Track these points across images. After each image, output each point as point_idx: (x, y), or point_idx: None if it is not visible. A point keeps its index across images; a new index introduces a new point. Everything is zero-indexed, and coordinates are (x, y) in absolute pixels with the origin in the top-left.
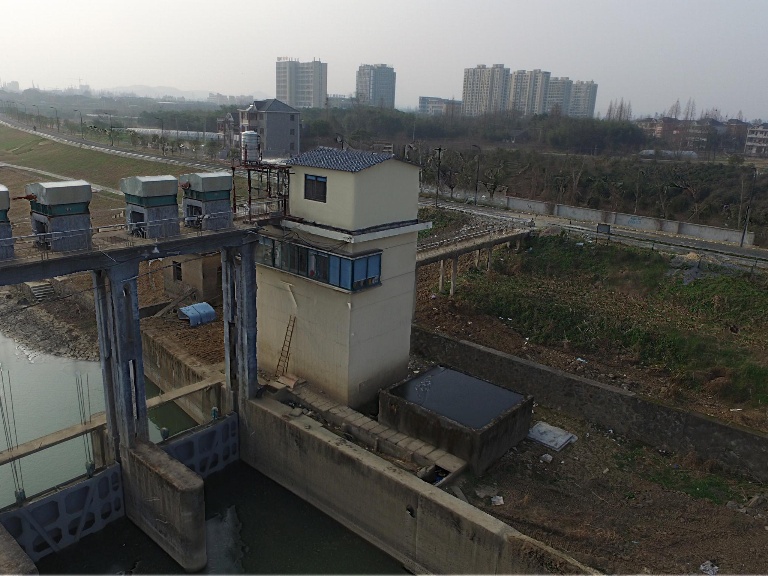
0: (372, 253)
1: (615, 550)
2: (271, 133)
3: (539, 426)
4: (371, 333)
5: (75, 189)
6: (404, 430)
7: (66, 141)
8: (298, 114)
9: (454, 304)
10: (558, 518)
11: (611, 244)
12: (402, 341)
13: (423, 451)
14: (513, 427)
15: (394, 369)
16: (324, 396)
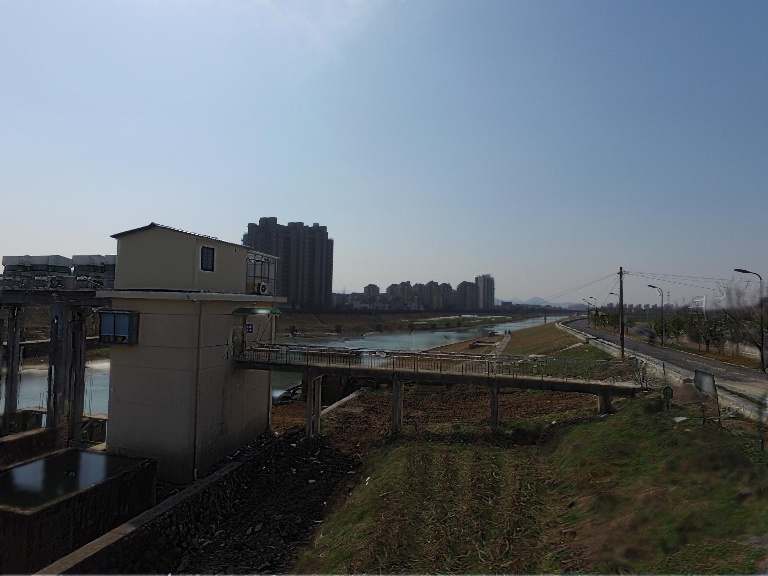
0: (117, 311)
1: None
2: None
3: None
4: (134, 398)
5: None
6: None
7: None
8: None
9: None
10: None
11: (747, 432)
12: (175, 426)
13: None
14: None
15: (165, 456)
16: None
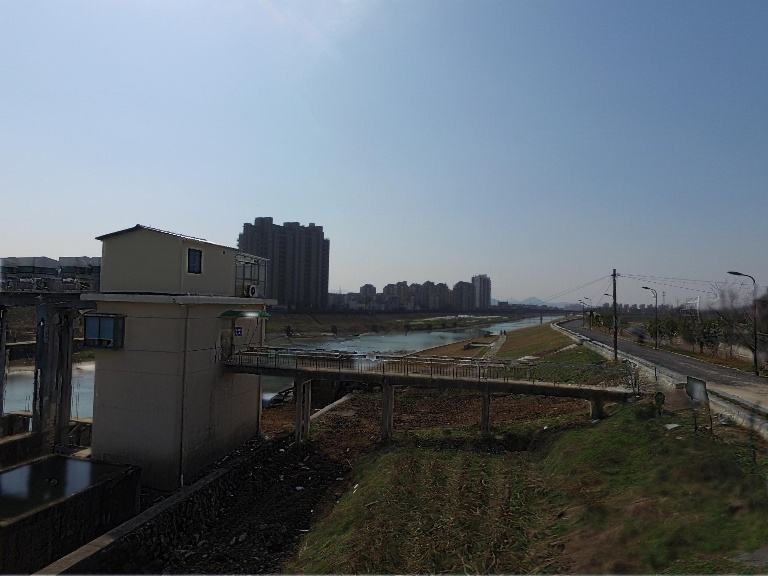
0: (102, 314)
1: None
2: None
3: None
4: (119, 403)
5: (28, 259)
6: None
7: None
8: None
9: None
10: None
11: (740, 441)
12: (161, 432)
13: None
14: None
15: (151, 462)
16: None
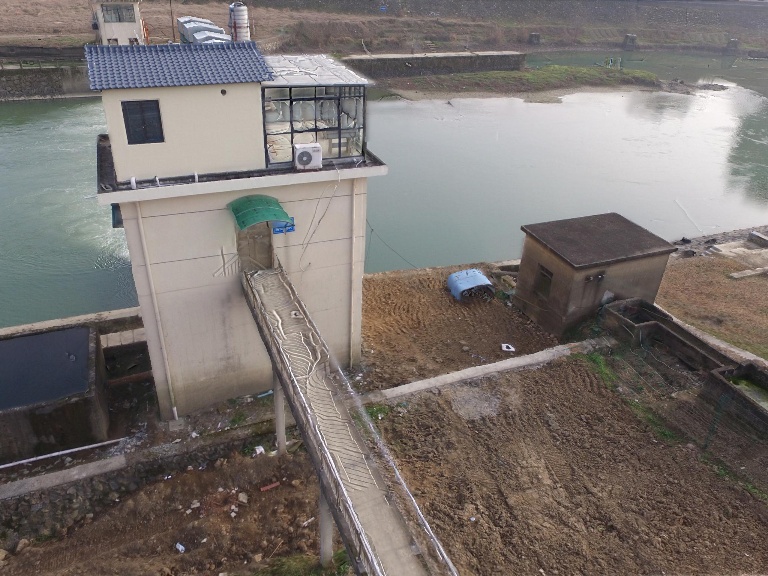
0: None
1: None
2: None
3: None
4: None
5: None
6: None
7: None
8: None
9: None
10: None
11: None
12: None
13: None
14: None
15: None
16: None
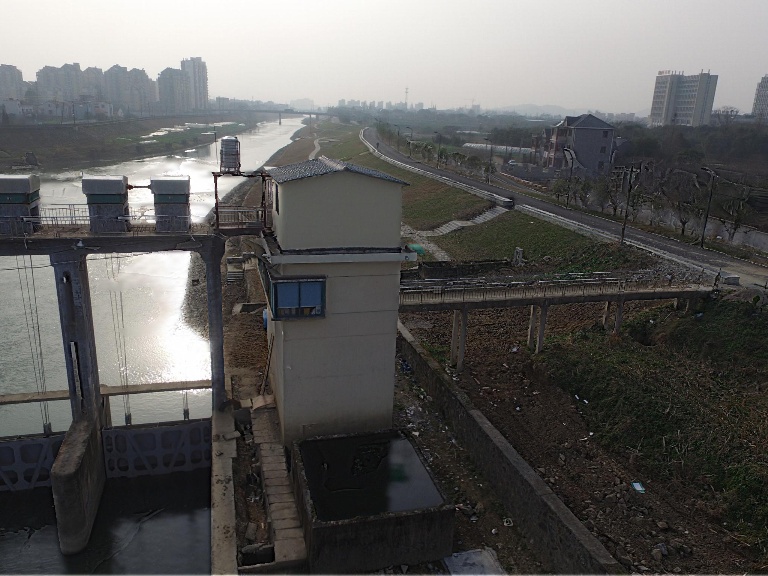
0: (305, 279)
1: None
2: (578, 150)
3: (475, 553)
4: (320, 371)
5: (13, 181)
6: (295, 492)
7: (376, 152)
8: (613, 130)
9: (532, 365)
10: None
11: None
12: (378, 390)
13: (281, 523)
14: (401, 538)
15: (364, 421)
16: (274, 428)
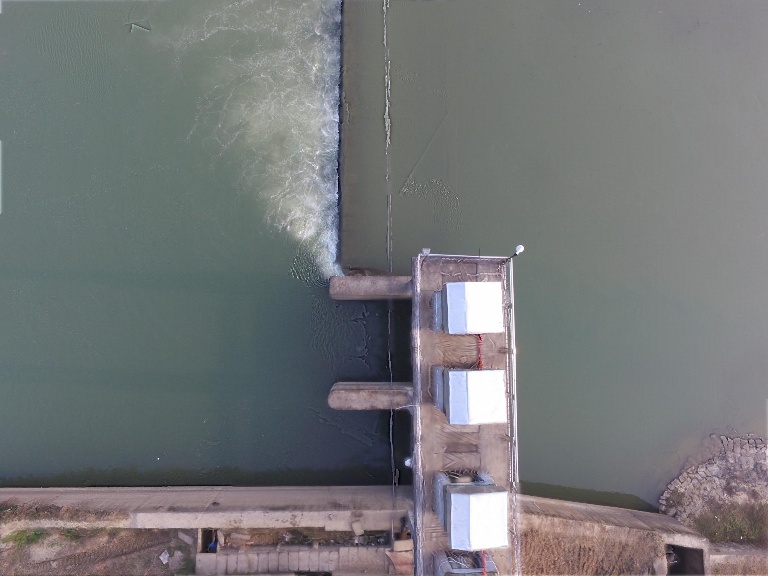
0: None
1: (77, 568)
2: None
3: None
4: None
5: None
6: (264, 575)
7: None
8: None
9: None
10: (119, 571)
11: None
12: None
13: (232, 560)
14: None
15: None
16: (359, 567)
